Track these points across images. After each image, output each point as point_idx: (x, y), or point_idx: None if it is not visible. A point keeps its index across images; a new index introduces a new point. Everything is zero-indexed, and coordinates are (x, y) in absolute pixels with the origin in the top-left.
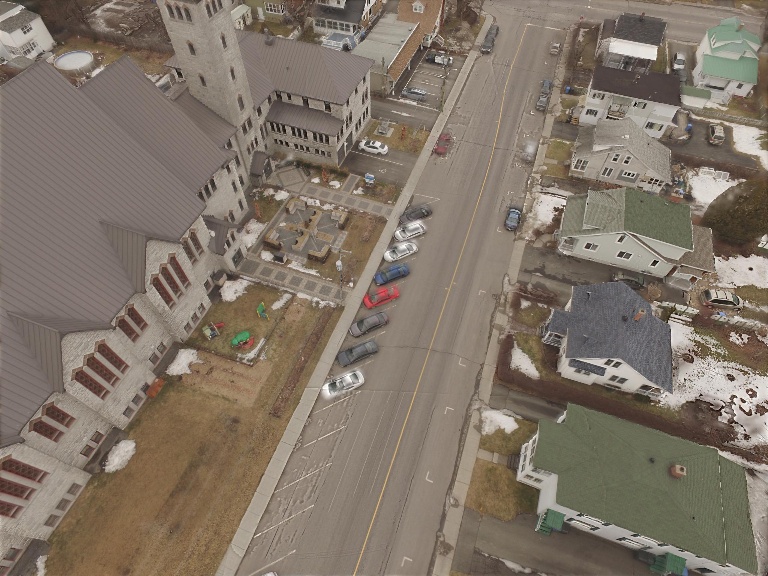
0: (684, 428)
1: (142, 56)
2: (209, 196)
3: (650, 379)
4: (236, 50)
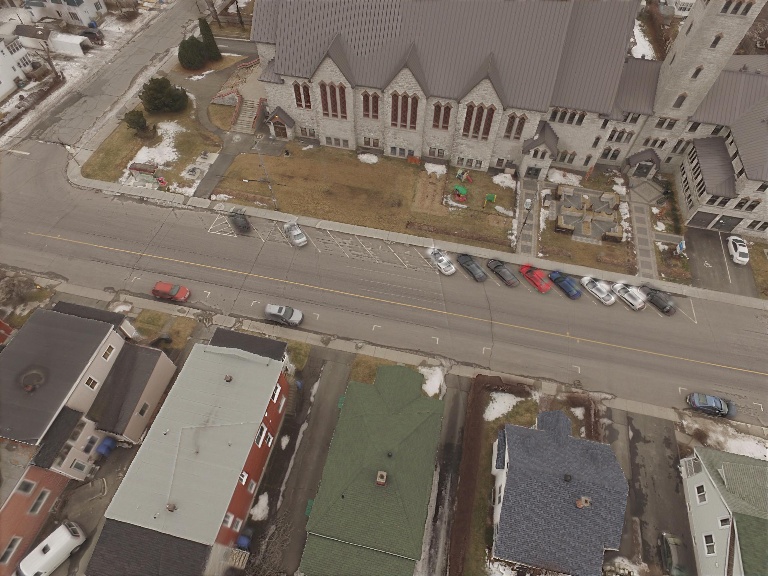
0: (457, 570)
1: None
2: (570, 123)
3: (503, 518)
4: (723, 59)
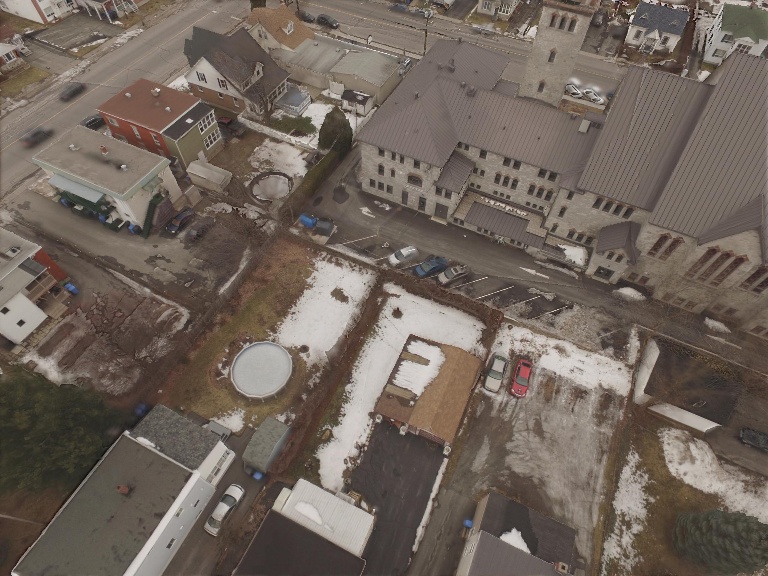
0: None
1: (256, 289)
2: None
3: None
4: None
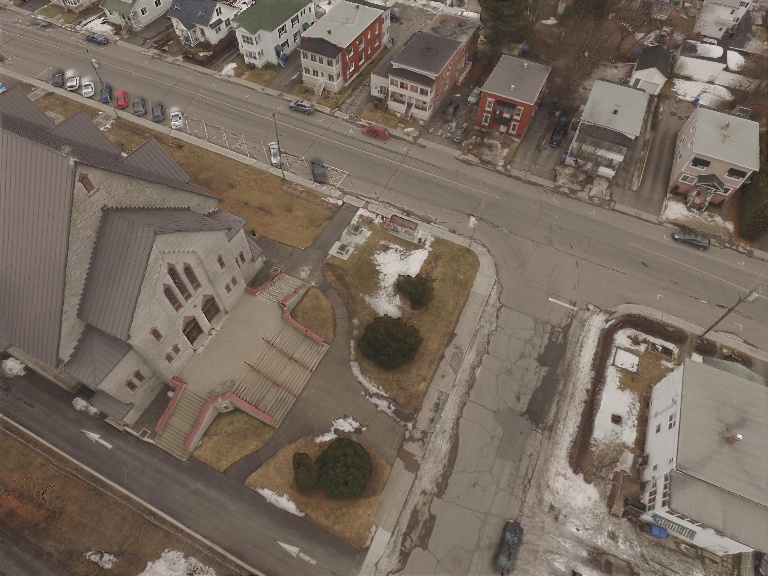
0: None
1: None
2: None
3: (232, 7)
4: None
